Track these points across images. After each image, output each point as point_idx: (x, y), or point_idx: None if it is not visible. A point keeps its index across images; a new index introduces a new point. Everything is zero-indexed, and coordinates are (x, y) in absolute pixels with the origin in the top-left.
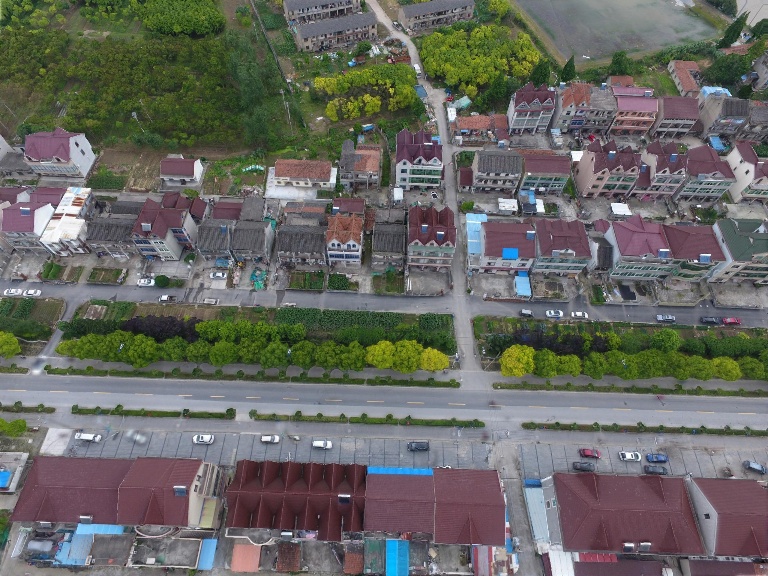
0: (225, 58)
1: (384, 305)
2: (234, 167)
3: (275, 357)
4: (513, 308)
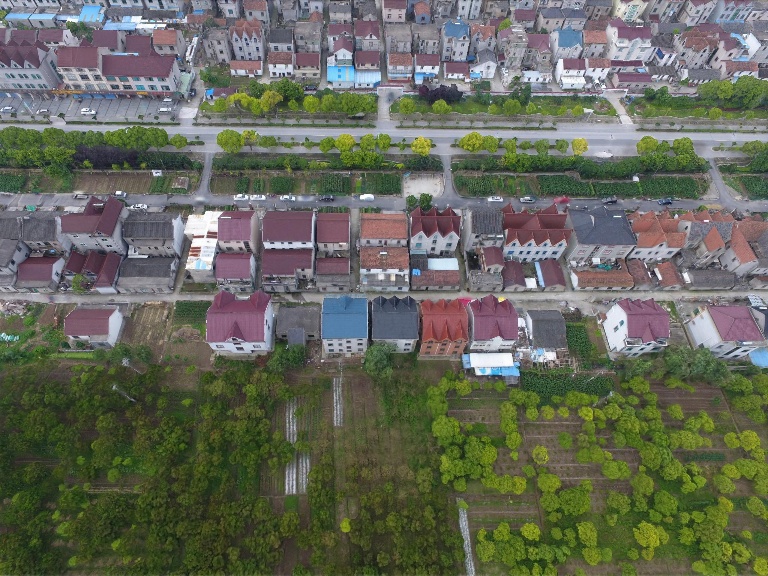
0: None
1: None
2: (30, 343)
3: (9, 128)
4: None
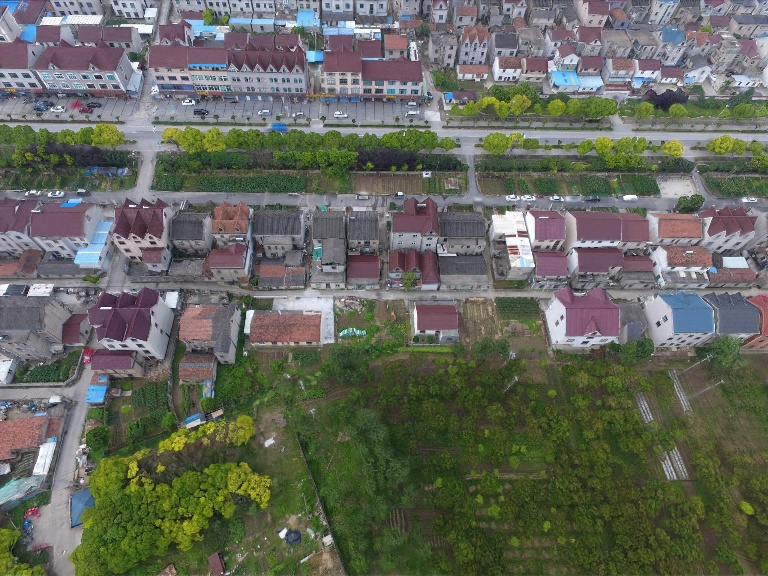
0: (450, 568)
1: (211, 198)
2: (378, 337)
3: (292, 131)
4: (93, 199)
